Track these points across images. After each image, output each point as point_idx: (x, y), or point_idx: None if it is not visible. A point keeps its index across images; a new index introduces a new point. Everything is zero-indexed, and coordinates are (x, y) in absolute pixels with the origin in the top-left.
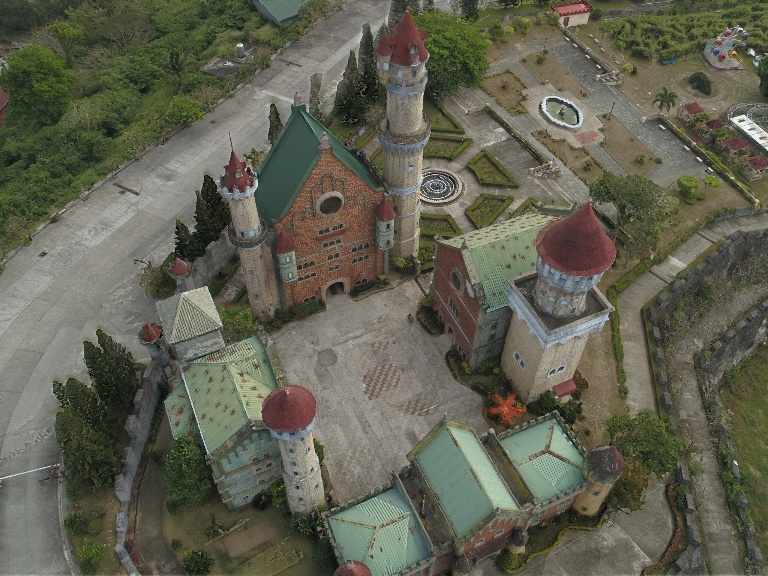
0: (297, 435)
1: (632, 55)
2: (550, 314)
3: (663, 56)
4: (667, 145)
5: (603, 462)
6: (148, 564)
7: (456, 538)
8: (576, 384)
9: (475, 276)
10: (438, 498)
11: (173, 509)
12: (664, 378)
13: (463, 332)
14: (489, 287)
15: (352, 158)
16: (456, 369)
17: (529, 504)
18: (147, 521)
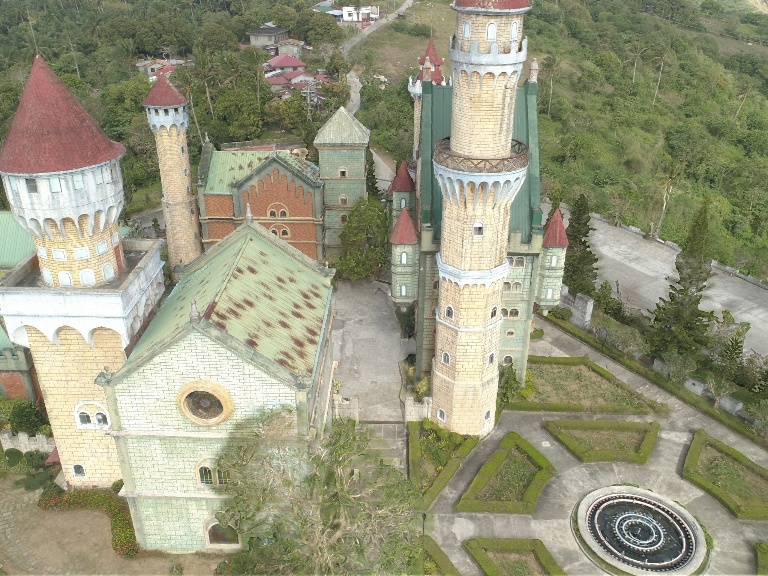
0: None
1: None
2: None
3: None
4: None
5: None
6: None
7: None
8: None
9: None
10: None
11: None
12: None
13: None
14: None
15: (517, 209)
16: None
17: None
18: None
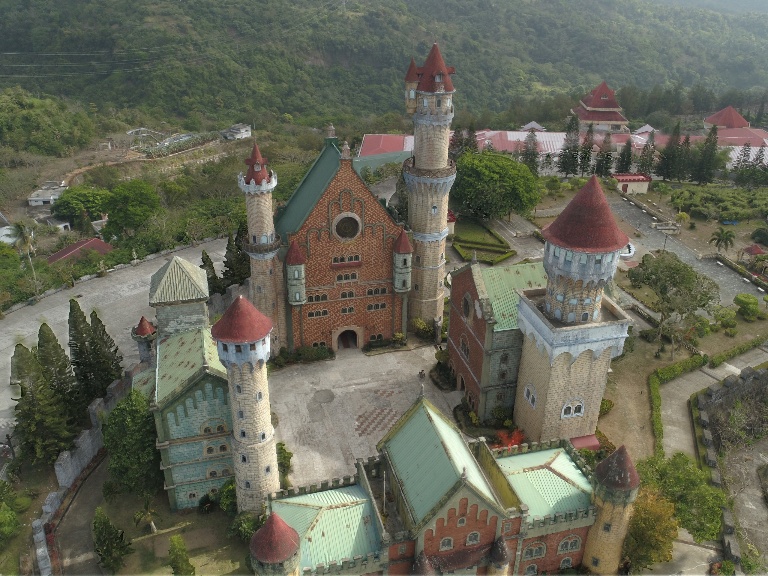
0: (244, 354)
1: (691, 216)
2: (559, 319)
3: (723, 216)
4: (725, 277)
5: (611, 469)
6: (62, 551)
7: (414, 524)
8: (601, 448)
9: (483, 291)
10: (402, 484)
11: (109, 492)
12: (712, 457)
13: (472, 373)
14: (499, 307)
15: None
16: (463, 420)
17: (514, 508)
18: (79, 511)
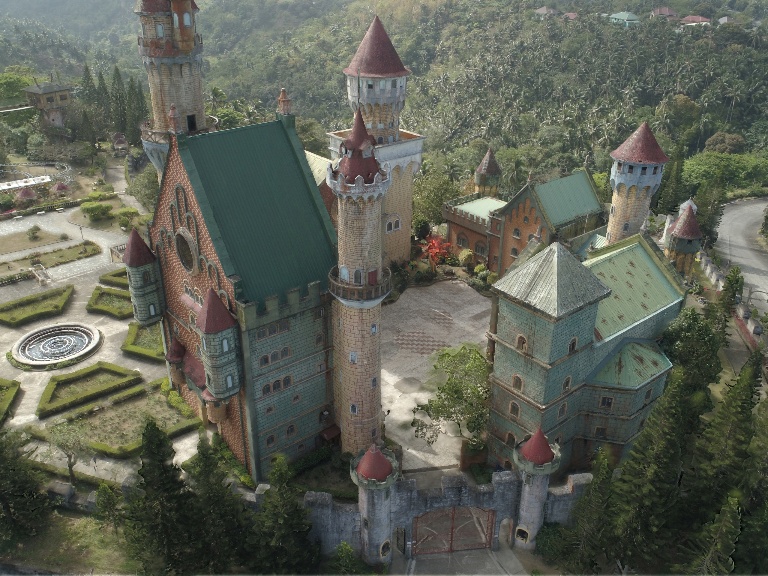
0: None
1: None
2: None
3: None
4: (7, 227)
5: None
6: None
7: (602, 210)
8: None
9: None
10: None
11: None
12: None
13: None
14: None
15: None
16: (384, 300)
17: None
18: None
